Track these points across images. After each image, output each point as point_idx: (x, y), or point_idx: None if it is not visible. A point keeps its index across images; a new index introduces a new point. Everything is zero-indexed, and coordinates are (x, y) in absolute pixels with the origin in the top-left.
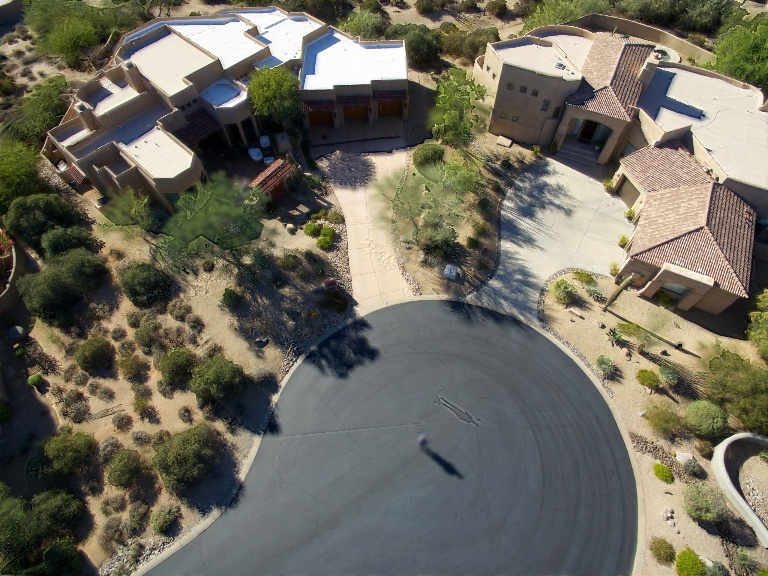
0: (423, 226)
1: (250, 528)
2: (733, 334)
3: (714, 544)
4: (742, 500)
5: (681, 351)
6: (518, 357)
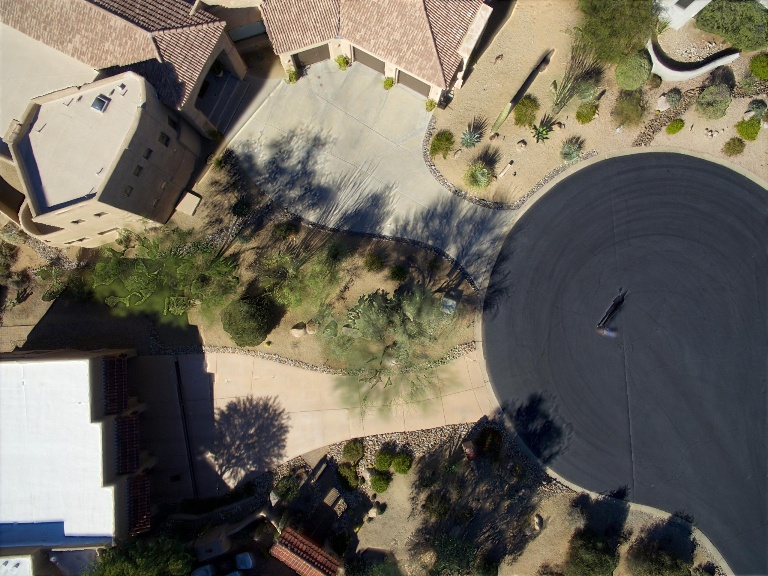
0: (373, 336)
1: (711, 501)
2: (510, 2)
3: (735, 105)
4: (706, 68)
5: (546, 67)
6: (555, 241)
